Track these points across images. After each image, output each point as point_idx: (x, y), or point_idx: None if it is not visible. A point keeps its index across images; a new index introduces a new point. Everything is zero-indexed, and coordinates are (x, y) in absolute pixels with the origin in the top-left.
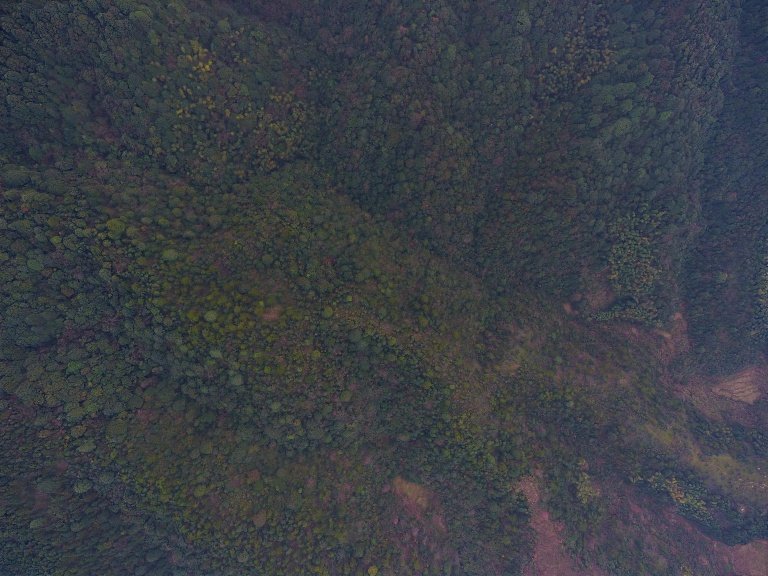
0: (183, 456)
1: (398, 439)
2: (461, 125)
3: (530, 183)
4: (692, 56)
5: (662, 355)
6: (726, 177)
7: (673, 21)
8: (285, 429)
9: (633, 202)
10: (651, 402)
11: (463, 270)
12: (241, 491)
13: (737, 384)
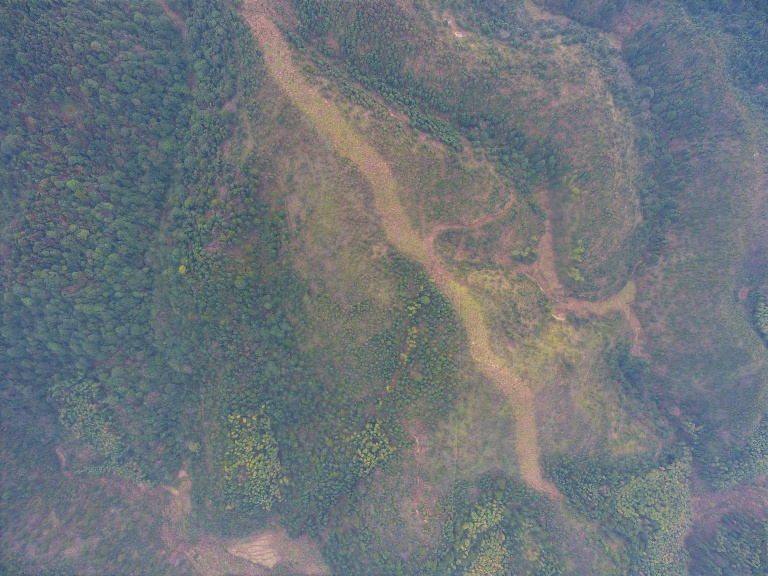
0: None
1: None
2: None
3: None
4: (34, 246)
5: (171, 511)
6: (170, 351)
7: None
8: None
9: (71, 369)
10: (109, 573)
11: None
12: None
13: (255, 547)
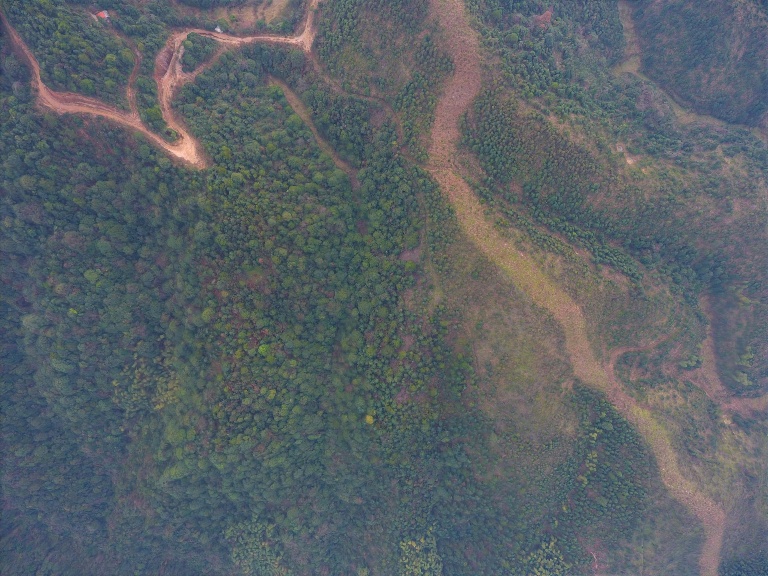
0: None
1: None
2: (49, 435)
3: (132, 491)
4: (231, 416)
5: None
6: (343, 487)
7: (215, 374)
8: None
9: None
10: None
11: (99, 552)
12: None
13: None
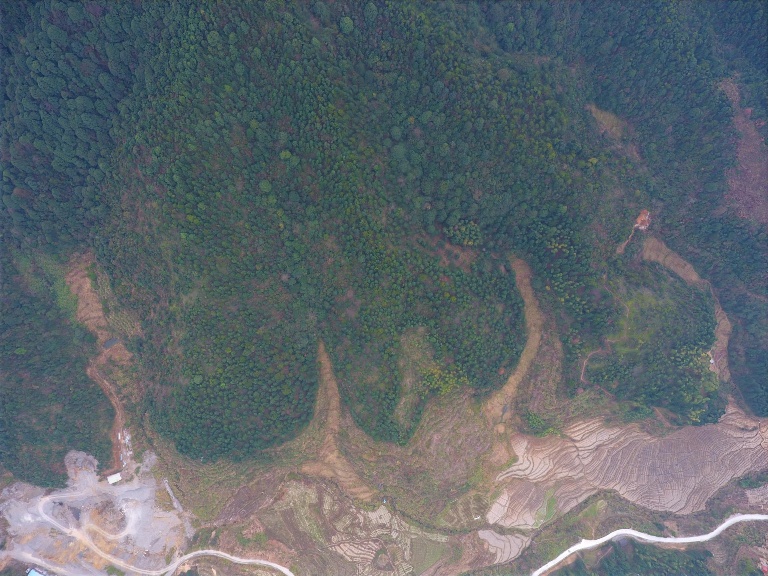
0: (431, 8)
1: (598, 53)
2: None
3: None
4: None
5: None
6: None
7: None
8: (507, 15)
9: None
10: None
11: None
12: (479, 58)
13: None
